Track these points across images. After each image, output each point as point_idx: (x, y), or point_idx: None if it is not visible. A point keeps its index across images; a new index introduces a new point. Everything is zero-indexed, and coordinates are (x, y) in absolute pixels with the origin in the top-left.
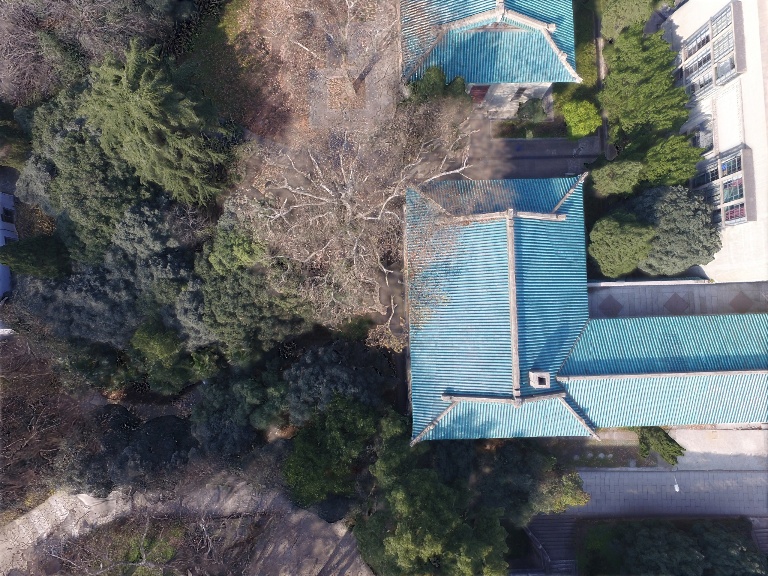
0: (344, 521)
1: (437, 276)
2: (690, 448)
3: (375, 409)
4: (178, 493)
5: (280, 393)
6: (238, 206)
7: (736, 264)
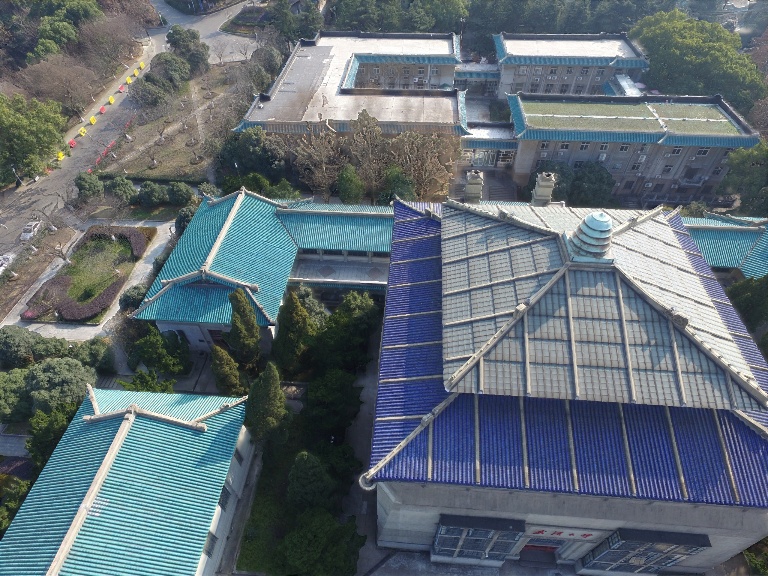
0: None
1: None
2: None
3: None
4: None
5: None
6: None
7: None
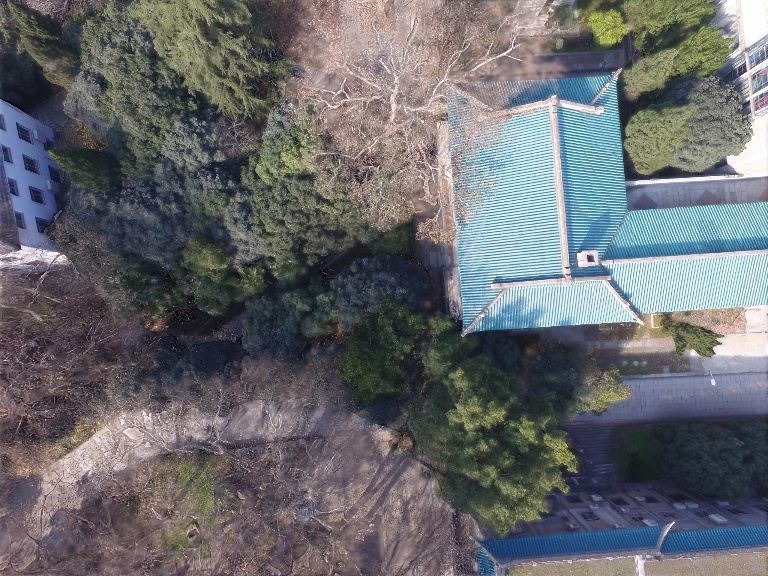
0: (387, 440)
1: (481, 171)
2: (721, 352)
3: (422, 312)
4: (244, 379)
5: (329, 299)
6: (284, 114)
7: (767, 151)
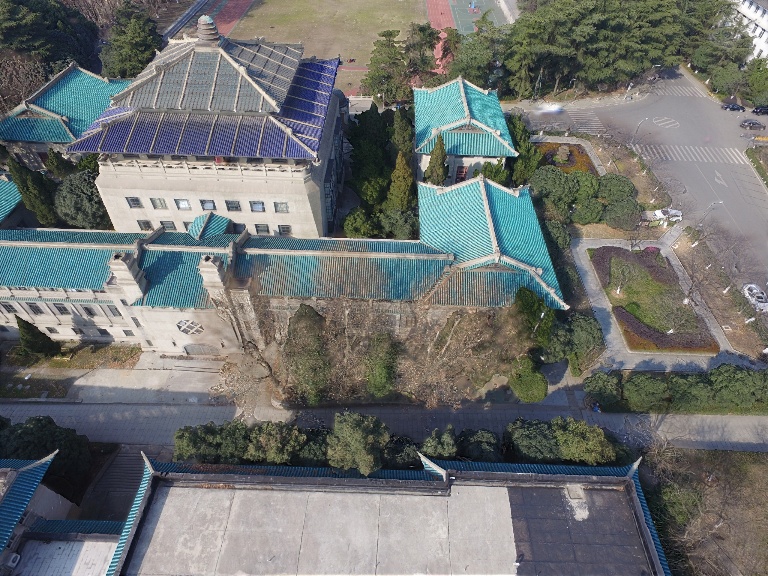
0: None
1: None
2: (102, 383)
3: None
4: None
5: None
6: None
7: None
